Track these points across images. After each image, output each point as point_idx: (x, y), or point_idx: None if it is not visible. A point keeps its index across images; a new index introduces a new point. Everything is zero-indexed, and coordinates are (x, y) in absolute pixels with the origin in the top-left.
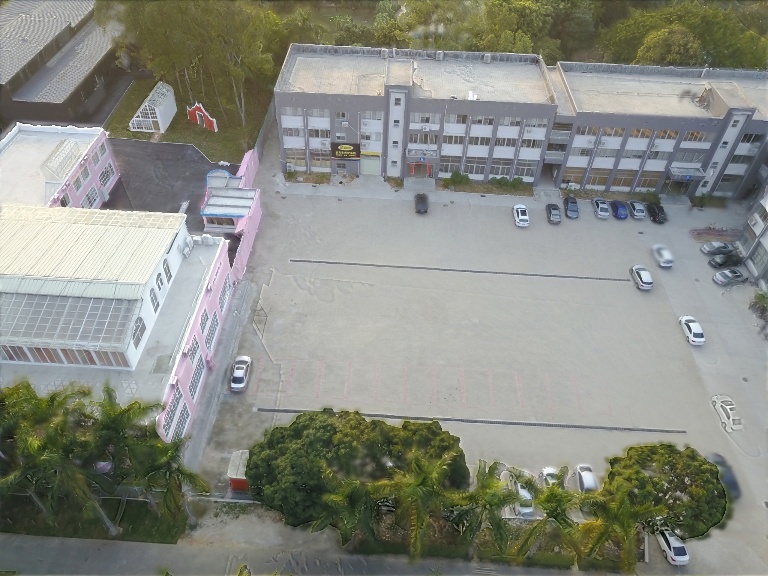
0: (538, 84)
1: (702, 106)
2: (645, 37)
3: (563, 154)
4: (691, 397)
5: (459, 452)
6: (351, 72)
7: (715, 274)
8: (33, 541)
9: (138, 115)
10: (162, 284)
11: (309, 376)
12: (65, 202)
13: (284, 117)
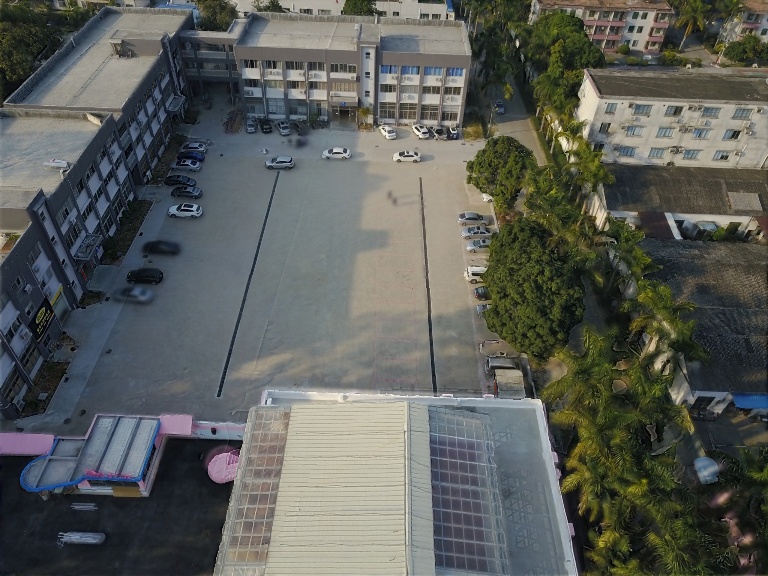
0: (47, 122)
1: (129, 56)
2: None
3: (133, 153)
4: (393, 169)
5: None
6: None
7: (278, 133)
8: None
9: None
10: None
11: (394, 367)
12: None
13: None
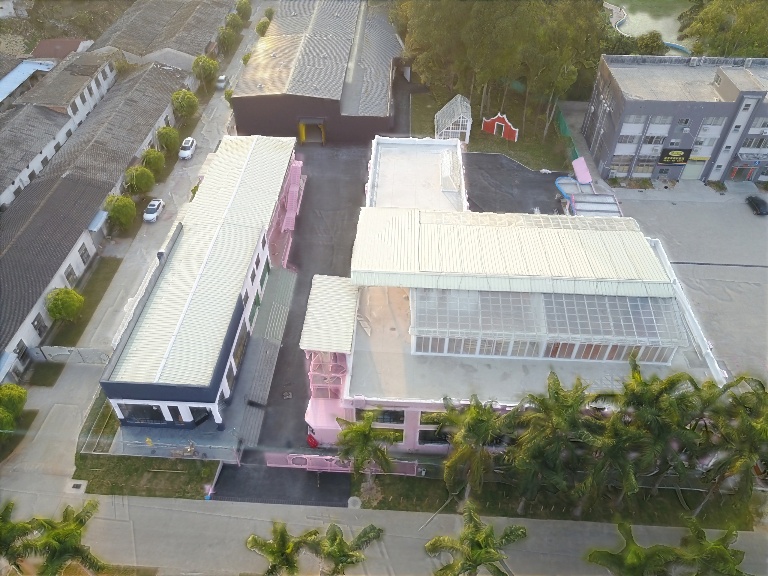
0: None
1: None
2: None
3: None
4: None
5: None
6: (673, 80)
7: None
8: None
9: (449, 127)
10: None
11: (758, 372)
12: None
13: (625, 125)
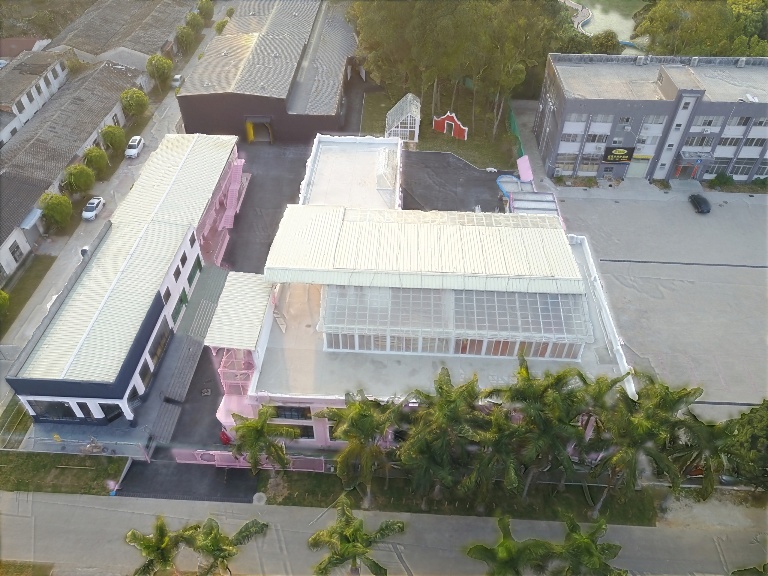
0: None
1: None
2: None
3: None
4: None
5: None
6: (617, 79)
7: None
8: (523, 524)
9: (397, 125)
10: None
11: (681, 369)
12: None
13: (567, 123)
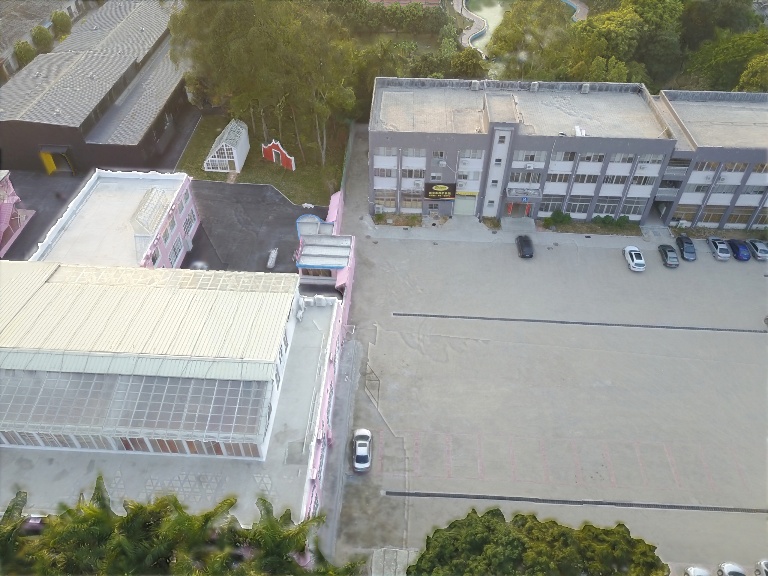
0: (646, 116)
1: None
2: (747, 61)
3: (677, 191)
4: None
5: (666, 569)
6: (443, 107)
7: None
8: None
9: (214, 155)
10: (282, 356)
11: (436, 452)
12: (155, 257)
13: (377, 157)
